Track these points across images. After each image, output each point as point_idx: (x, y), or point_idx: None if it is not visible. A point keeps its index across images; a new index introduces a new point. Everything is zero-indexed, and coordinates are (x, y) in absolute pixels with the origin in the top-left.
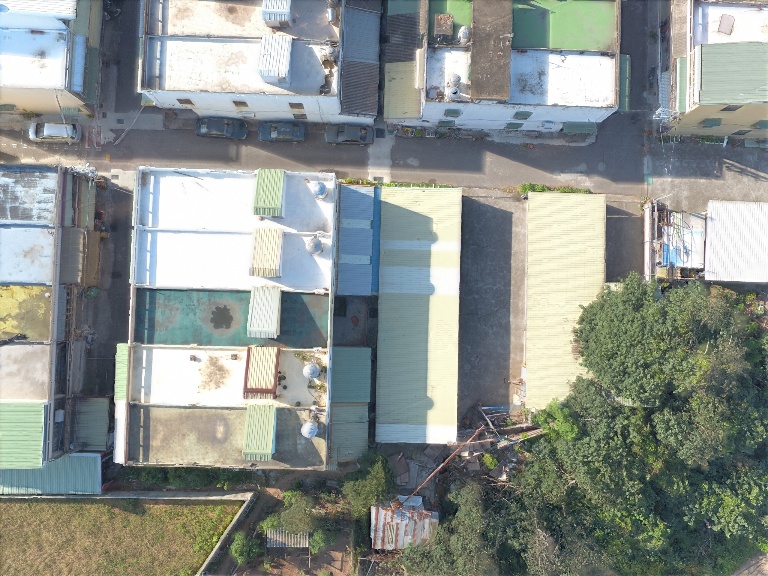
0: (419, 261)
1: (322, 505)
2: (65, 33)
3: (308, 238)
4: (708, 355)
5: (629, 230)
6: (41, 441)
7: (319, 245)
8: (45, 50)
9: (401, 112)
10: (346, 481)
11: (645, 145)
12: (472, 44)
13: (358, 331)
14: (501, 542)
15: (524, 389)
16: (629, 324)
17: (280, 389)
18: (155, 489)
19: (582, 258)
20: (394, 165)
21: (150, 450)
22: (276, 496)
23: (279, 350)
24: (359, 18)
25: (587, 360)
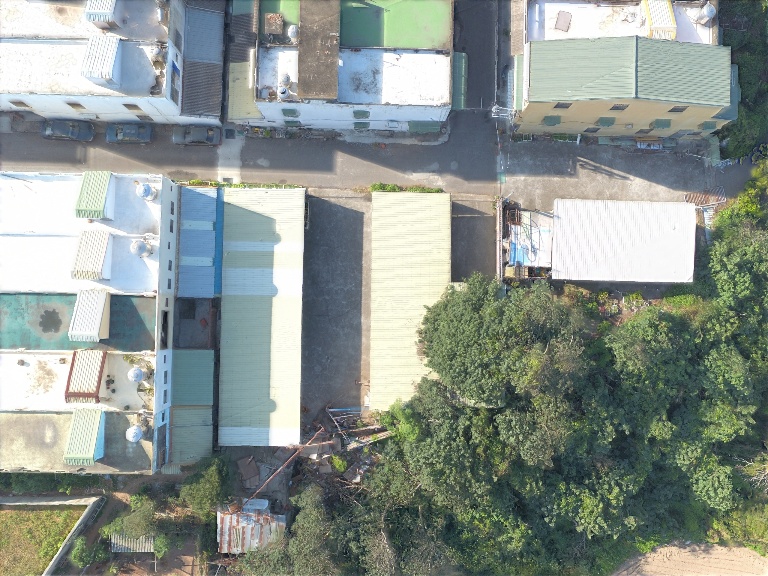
0: (262, 262)
1: (172, 509)
2: None
3: None
4: (547, 355)
5: (482, 229)
6: None
7: (143, 247)
8: None
9: (244, 113)
10: (182, 485)
11: (498, 144)
12: (299, 43)
13: (207, 333)
14: (344, 545)
15: None
16: (467, 324)
17: (109, 393)
18: (1, 494)
19: (427, 258)
20: (244, 166)
21: None
22: (124, 500)
23: (105, 354)
24: (201, 18)
25: (432, 361)
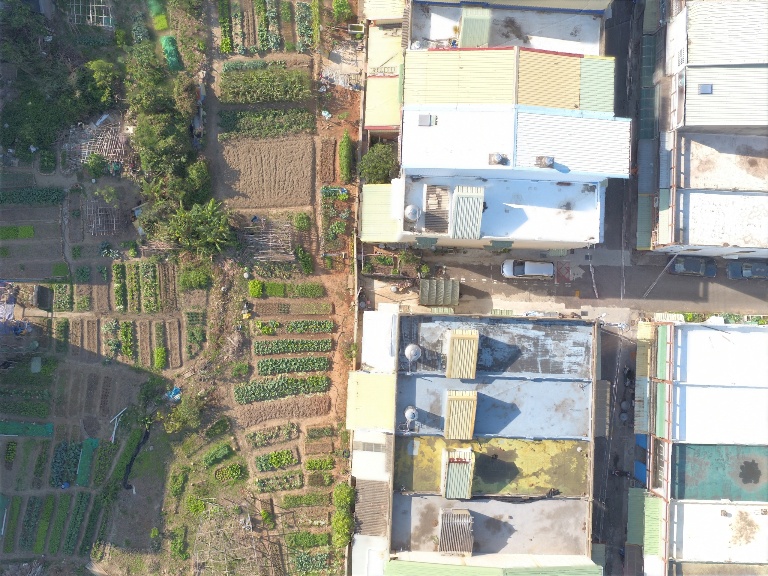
0: None
1: None
2: (592, 185)
3: None
4: None
5: None
6: None
7: None
8: (570, 201)
9: None
10: None
11: None
12: None
13: None
14: None
15: None
16: None
17: None
18: None
19: None
20: None
21: None
22: None
23: None
24: None
25: None
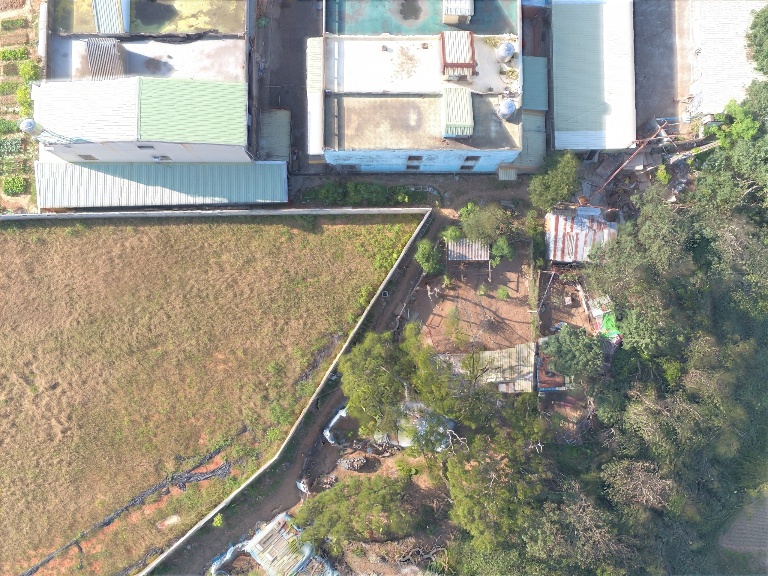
0: None
1: None
2: None
3: None
4: None
5: None
6: (245, 119)
7: None
8: None
9: None
10: (534, 176)
11: None
12: None
13: (526, 54)
14: (686, 241)
15: (696, 101)
16: None
17: (472, 76)
18: None
19: None
20: None
21: (345, 139)
22: (452, 216)
23: (472, 33)
24: None
25: None
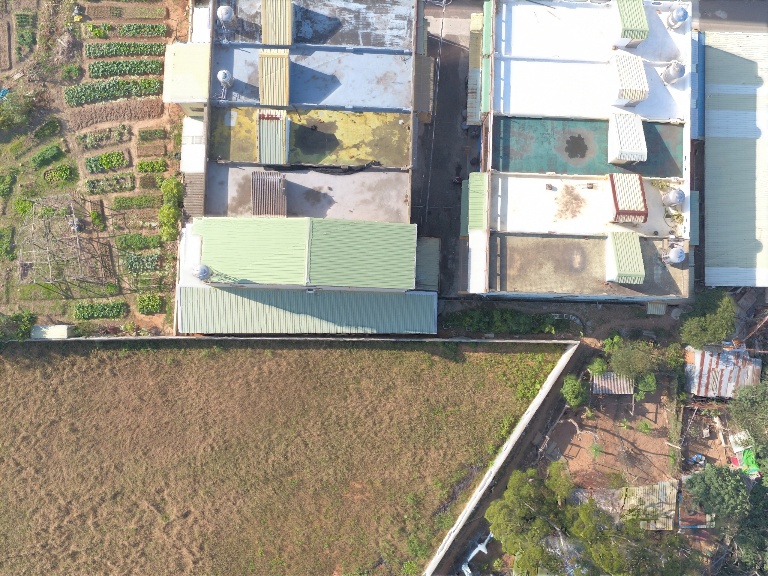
0: (745, 105)
1: None
2: None
3: (661, 68)
4: None
5: None
6: (414, 261)
7: (683, 70)
8: None
9: None
10: (690, 318)
11: None
12: None
13: None
14: None
15: None
16: None
17: None
18: (474, 337)
19: None
20: (702, 17)
21: (507, 279)
22: (593, 346)
23: (641, 177)
24: None
25: None
